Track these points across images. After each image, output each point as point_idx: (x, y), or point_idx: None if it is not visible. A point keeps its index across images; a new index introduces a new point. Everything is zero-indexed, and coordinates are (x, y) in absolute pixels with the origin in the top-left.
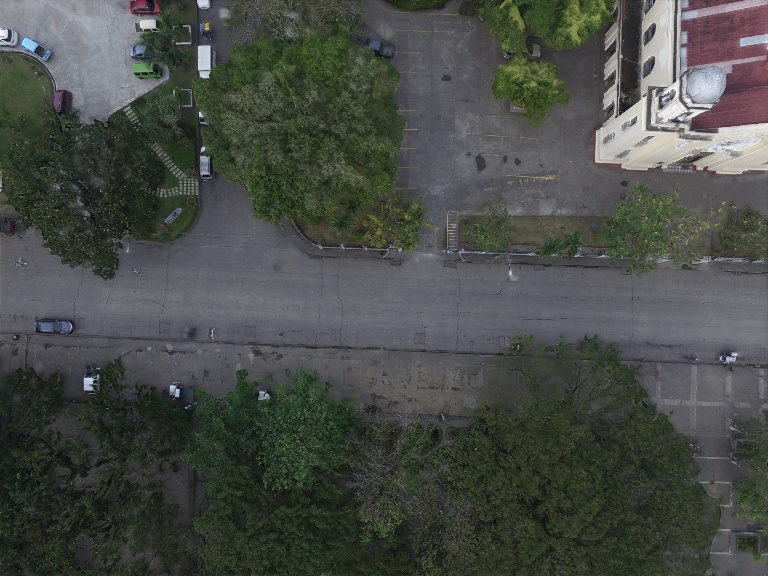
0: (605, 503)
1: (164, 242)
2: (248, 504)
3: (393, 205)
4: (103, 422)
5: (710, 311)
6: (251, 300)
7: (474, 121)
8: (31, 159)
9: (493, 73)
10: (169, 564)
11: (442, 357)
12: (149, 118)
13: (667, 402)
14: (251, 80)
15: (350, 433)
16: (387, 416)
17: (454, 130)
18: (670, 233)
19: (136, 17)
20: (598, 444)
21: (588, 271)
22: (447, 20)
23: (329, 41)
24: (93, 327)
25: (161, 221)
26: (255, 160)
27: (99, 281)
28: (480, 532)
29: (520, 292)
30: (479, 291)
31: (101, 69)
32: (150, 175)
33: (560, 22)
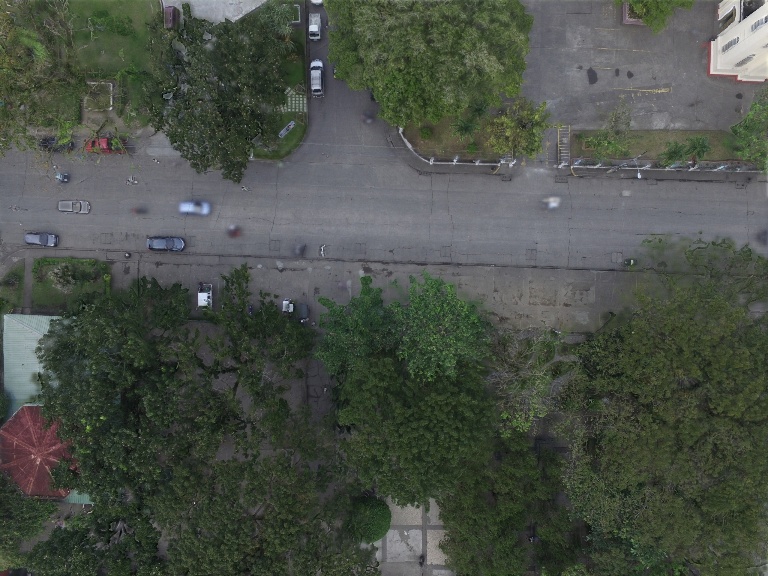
0: (767, 384)
1: (273, 159)
2: (393, 395)
3: (519, 108)
4: None
5: None
6: (361, 217)
7: (585, 34)
8: (169, 54)
9: None
10: (309, 459)
11: (554, 273)
12: None
13: None
14: None
15: (483, 333)
16: None
17: (565, 43)
18: None
19: None
20: (756, 328)
21: (702, 185)
22: None
23: None
24: (204, 245)
25: None
26: (394, 52)
27: (209, 199)
28: (640, 414)
29: (633, 207)
30: (591, 206)
31: None
32: None
33: None
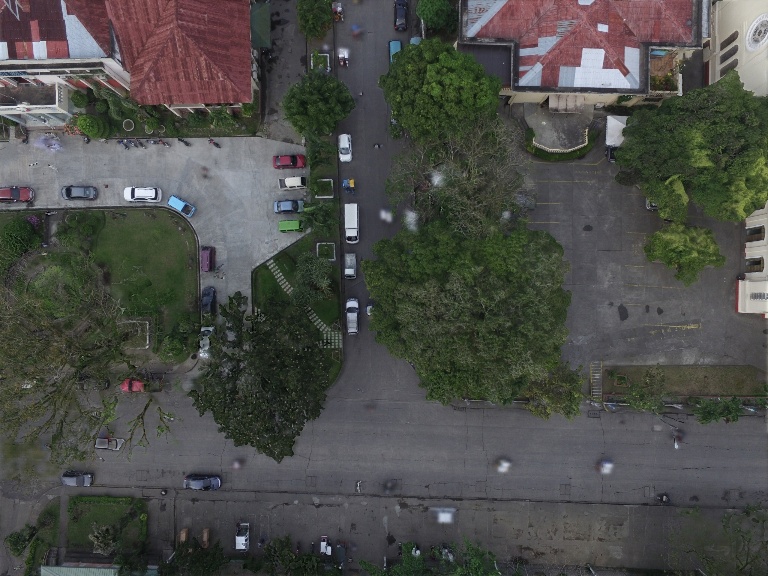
0: None
1: None
2: None
3: (558, 379)
4: None
5: None
6: (397, 453)
7: (616, 271)
8: None
9: (648, 238)
10: None
11: (588, 508)
12: (301, 281)
13: None
14: (431, 273)
15: None
16: (534, 568)
17: (596, 280)
18: None
19: (277, 170)
20: None
21: None
22: (587, 170)
23: (512, 237)
24: (240, 481)
25: None
26: (441, 358)
27: None
28: None
29: (664, 442)
30: (623, 441)
31: (243, 223)
32: None
33: (725, 197)
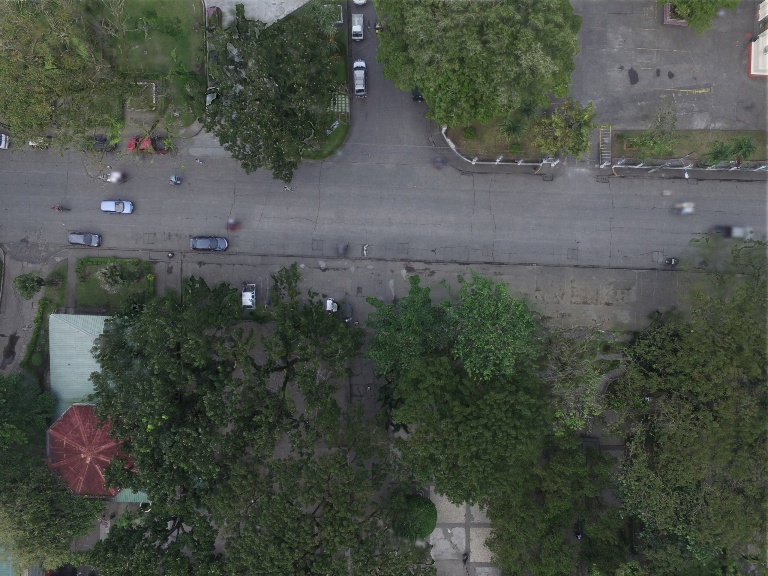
0: None
1: (316, 159)
2: (450, 394)
3: (568, 108)
4: None
5: None
6: (403, 217)
7: (626, 34)
8: (224, 55)
9: None
10: (363, 458)
11: (595, 272)
12: None
13: None
14: None
15: None
16: None
17: (606, 44)
18: None
19: None
20: None
21: (742, 185)
22: None
23: None
24: (246, 245)
25: None
26: (450, 53)
27: (252, 199)
28: (700, 412)
29: (674, 207)
30: (632, 206)
31: None
32: None
33: None
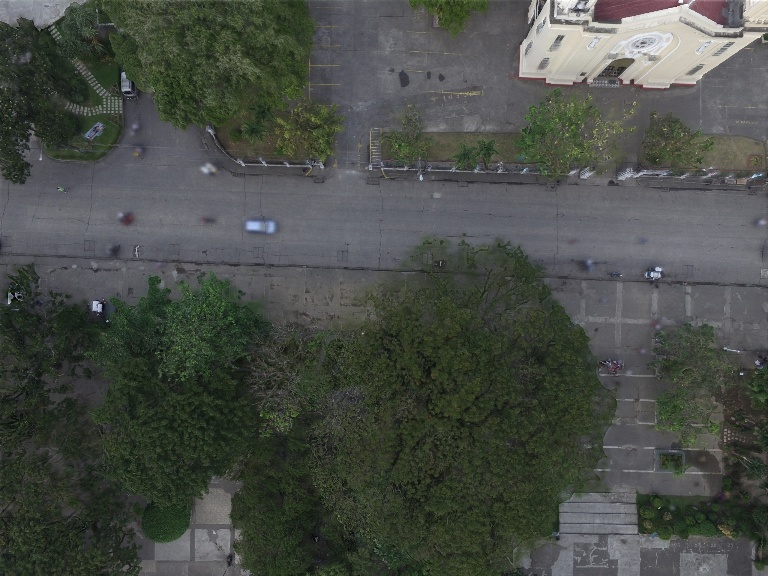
0: (490, 385)
1: (88, 160)
2: (145, 395)
3: (303, 110)
4: (13, 323)
5: (636, 228)
6: (174, 218)
7: (397, 37)
8: None
9: None
10: (73, 458)
11: (365, 274)
12: (68, 32)
13: (592, 319)
14: None
15: (255, 334)
16: None
17: (377, 46)
18: (583, 136)
19: None
20: (486, 329)
21: (512, 188)
22: None
23: None
24: (19, 245)
25: (85, 139)
26: (153, 55)
27: (25, 199)
28: (365, 414)
29: (443, 209)
30: (402, 208)
31: None
32: (72, 92)
33: None
